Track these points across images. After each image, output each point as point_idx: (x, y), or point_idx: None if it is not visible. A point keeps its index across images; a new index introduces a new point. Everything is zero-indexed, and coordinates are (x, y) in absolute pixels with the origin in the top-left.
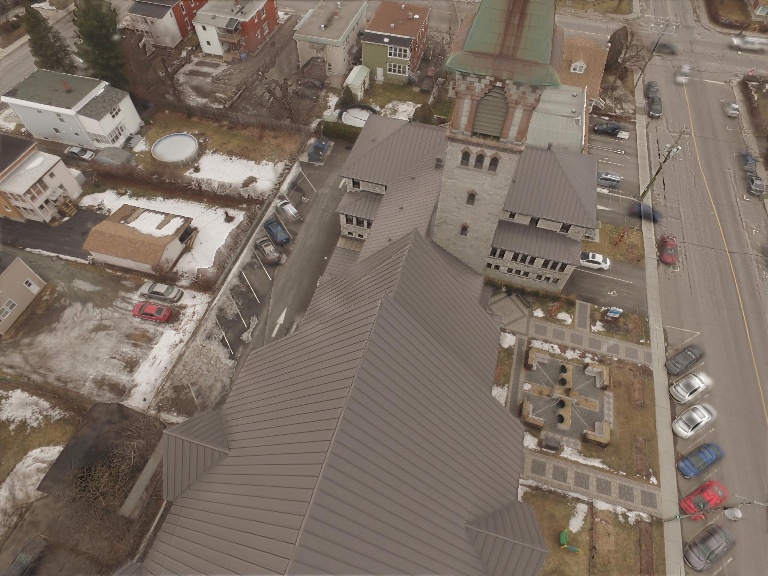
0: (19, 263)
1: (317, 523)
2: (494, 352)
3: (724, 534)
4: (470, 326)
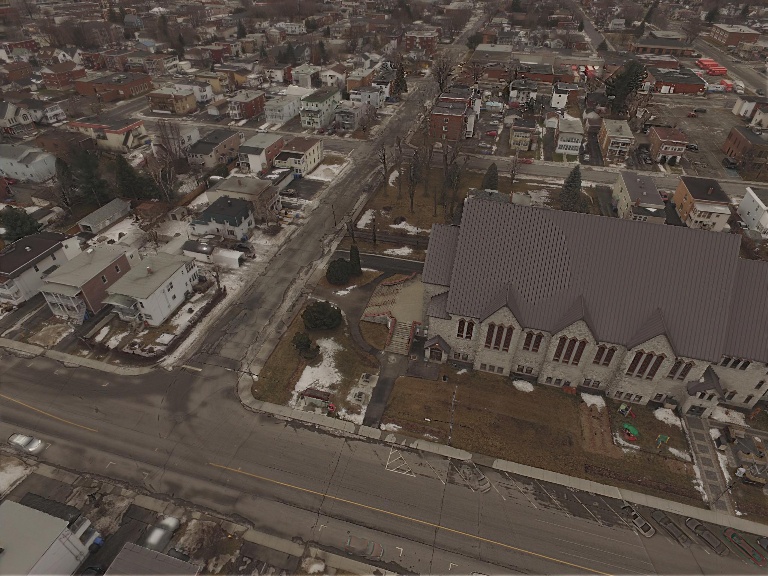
0: (663, 221)
1: (650, 228)
2: (759, 356)
3: (726, 555)
4: (764, 327)
